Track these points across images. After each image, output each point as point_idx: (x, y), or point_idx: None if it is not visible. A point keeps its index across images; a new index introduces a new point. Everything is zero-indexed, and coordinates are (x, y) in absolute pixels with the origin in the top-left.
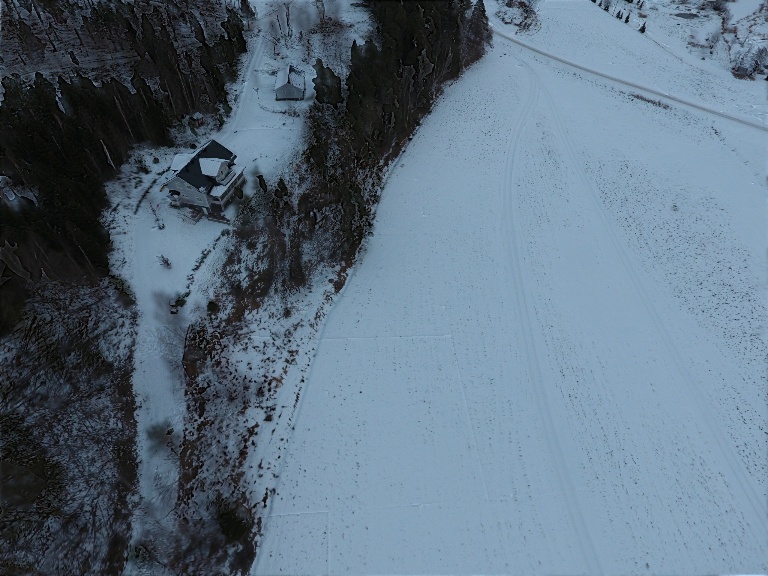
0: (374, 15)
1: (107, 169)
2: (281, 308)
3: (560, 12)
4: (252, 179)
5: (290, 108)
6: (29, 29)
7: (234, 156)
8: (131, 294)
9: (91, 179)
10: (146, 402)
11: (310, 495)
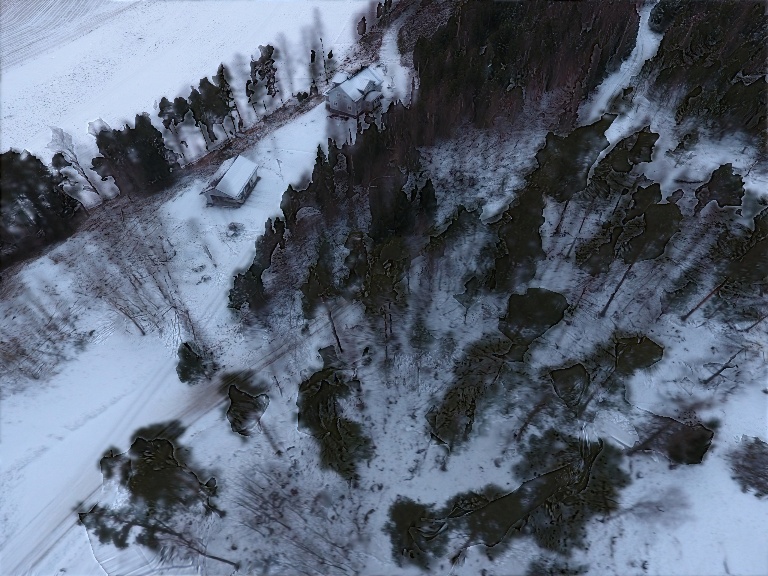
0: None
1: None
2: None
3: None
4: (321, 109)
5: None
6: None
7: None
8: None
9: None
10: None
11: None
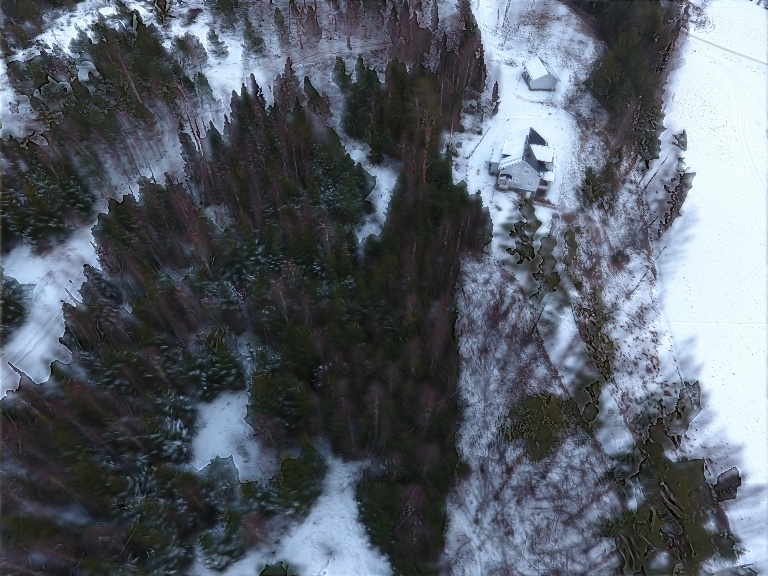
0: (572, 8)
1: (439, 151)
2: (620, 291)
3: (726, 10)
4: None
5: (547, 98)
6: (314, 14)
7: (547, 143)
8: (509, 271)
9: (449, 160)
10: (566, 372)
11: (744, 466)
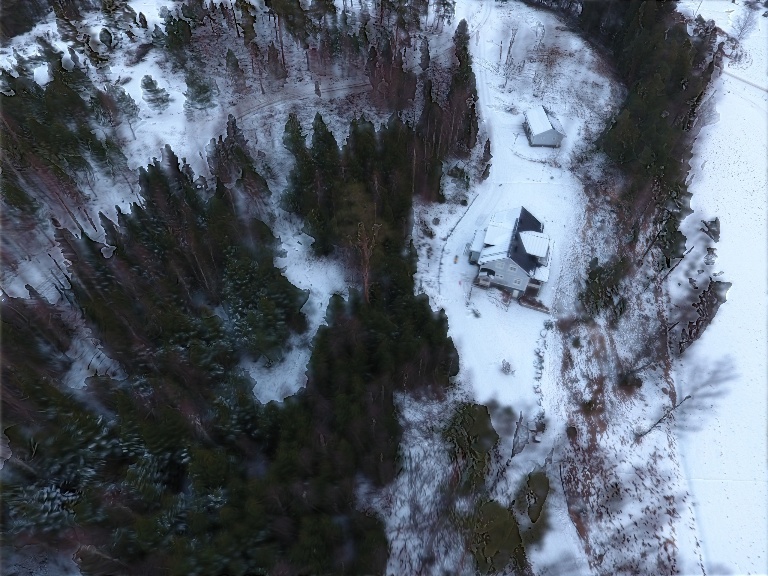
0: (587, 42)
1: (406, 236)
2: (628, 429)
3: (765, 41)
4: None
5: (549, 157)
6: (276, 55)
7: (542, 226)
8: None
9: (412, 256)
10: (545, 575)
11: None
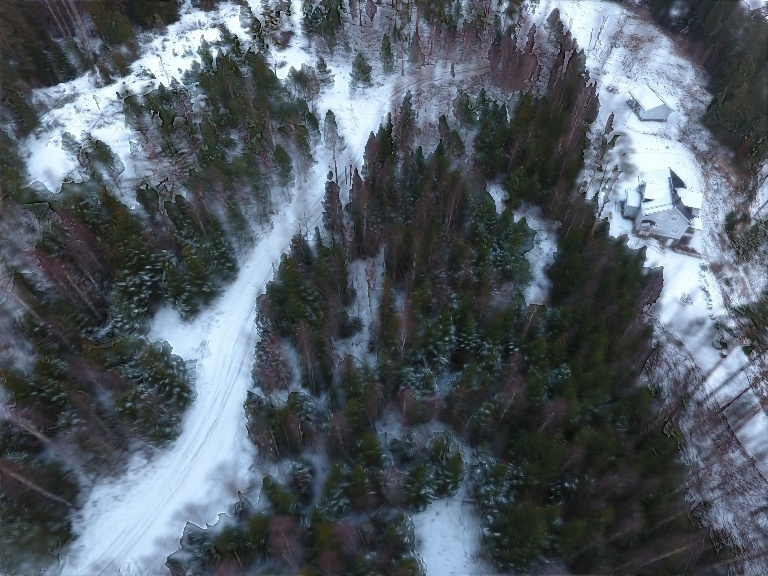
0: (660, 29)
1: None
2: None
3: None
4: None
5: (660, 130)
6: (418, 40)
7: (685, 185)
8: (673, 333)
9: (595, 207)
10: (757, 456)
11: None
